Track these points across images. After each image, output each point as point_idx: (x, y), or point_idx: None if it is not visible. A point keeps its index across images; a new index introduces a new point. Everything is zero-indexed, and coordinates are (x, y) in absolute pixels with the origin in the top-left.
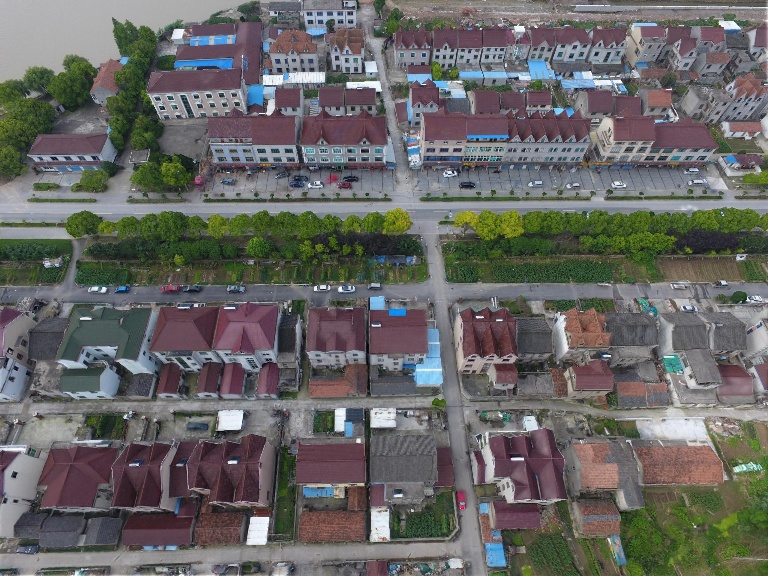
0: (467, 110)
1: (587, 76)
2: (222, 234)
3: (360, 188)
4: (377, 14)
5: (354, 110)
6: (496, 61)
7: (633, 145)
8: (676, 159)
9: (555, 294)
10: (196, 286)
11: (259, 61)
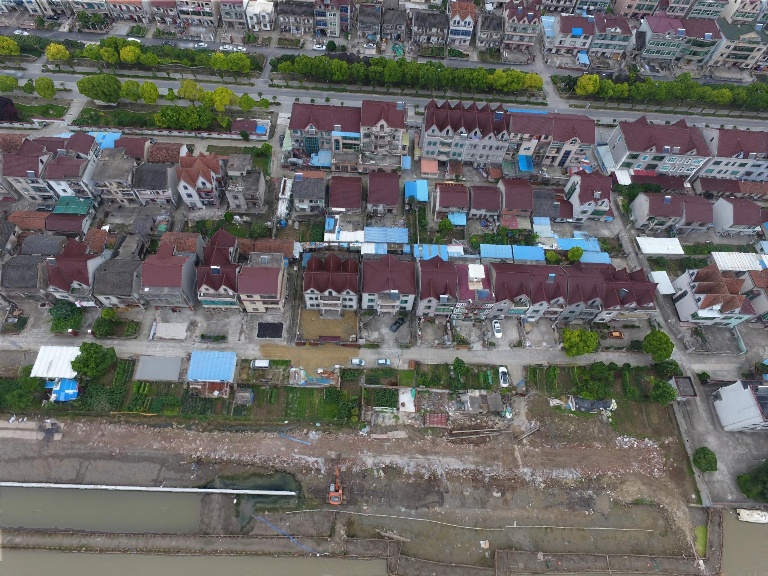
0: None
1: (369, 247)
2: None
3: None
4: None
5: None
6: None
7: None
8: None
9: (459, 63)
10: None
11: None
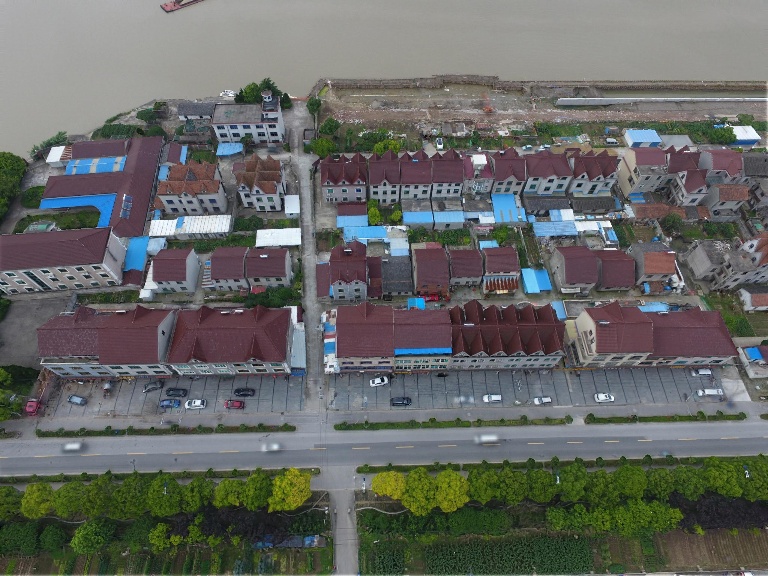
0: (408, 276)
1: (567, 216)
2: (42, 513)
3: (255, 407)
4: (312, 116)
5: (259, 281)
6: (451, 195)
7: (623, 355)
8: (681, 362)
9: None
10: None
11: (149, 198)
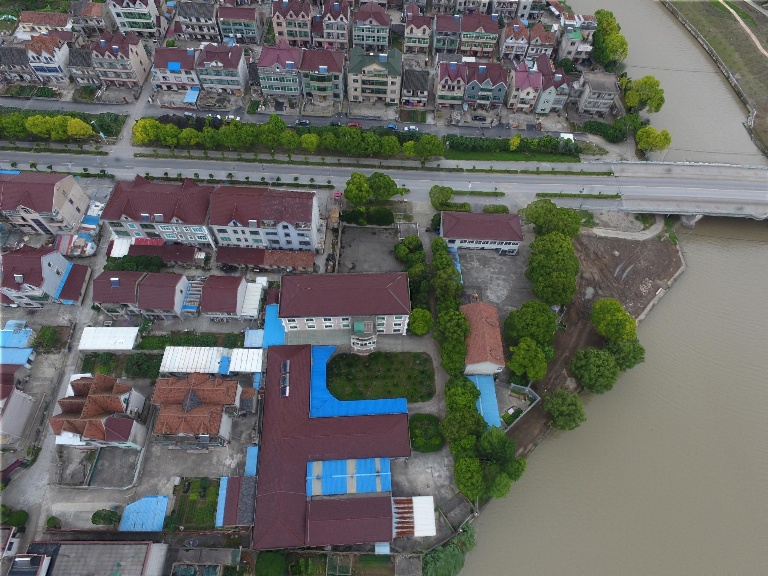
0: None
1: None
2: None
3: None
4: None
5: None
6: None
7: None
8: None
9: (45, 104)
10: (333, 124)
11: (265, 405)
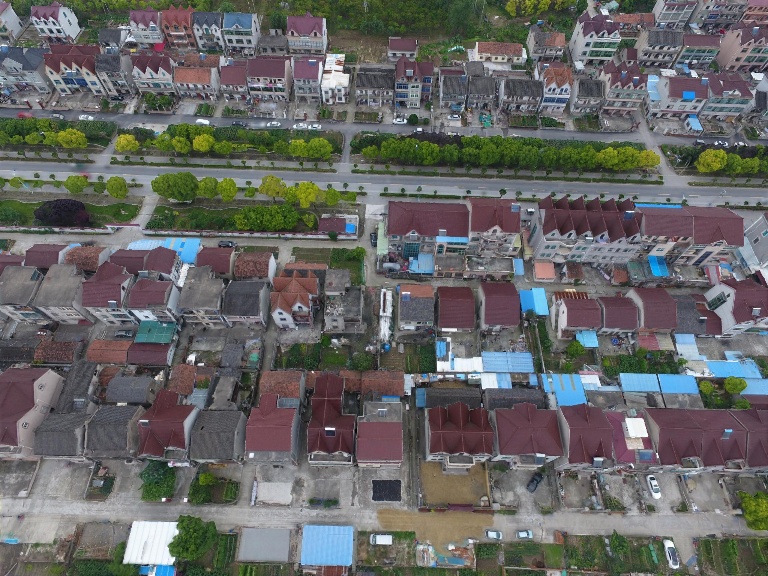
0: None
1: (490, 379)
2: None
3: (754, 221)
4: None
5: None
6: None
7: None
8: None
9: (555, 134)
10: None
11: None
